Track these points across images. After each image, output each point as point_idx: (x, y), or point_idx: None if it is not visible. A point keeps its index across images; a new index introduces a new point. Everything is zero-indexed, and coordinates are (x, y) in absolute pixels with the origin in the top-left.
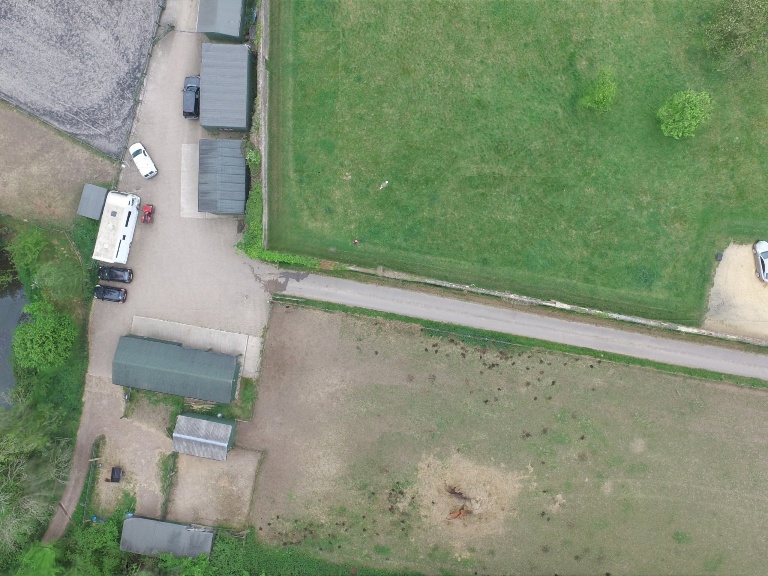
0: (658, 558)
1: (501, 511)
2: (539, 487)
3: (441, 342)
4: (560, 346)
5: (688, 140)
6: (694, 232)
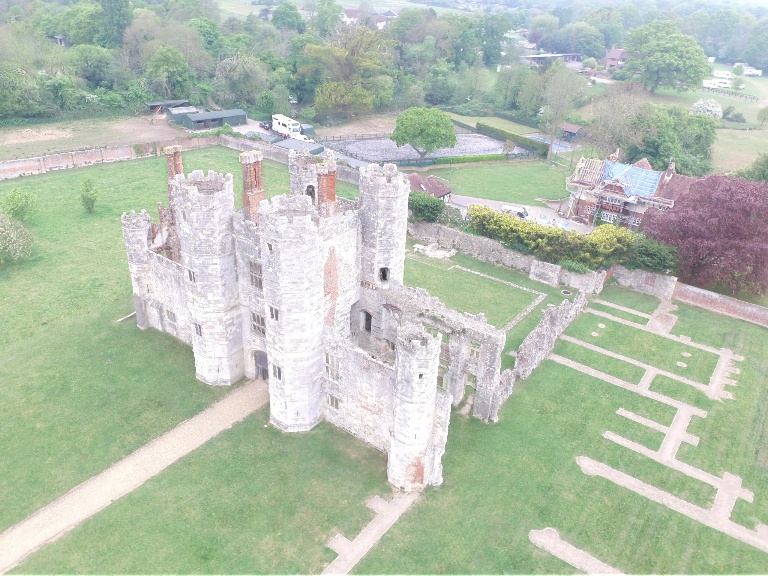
0: None
1: None
2: None
3: None
4: None
5: None
6: None
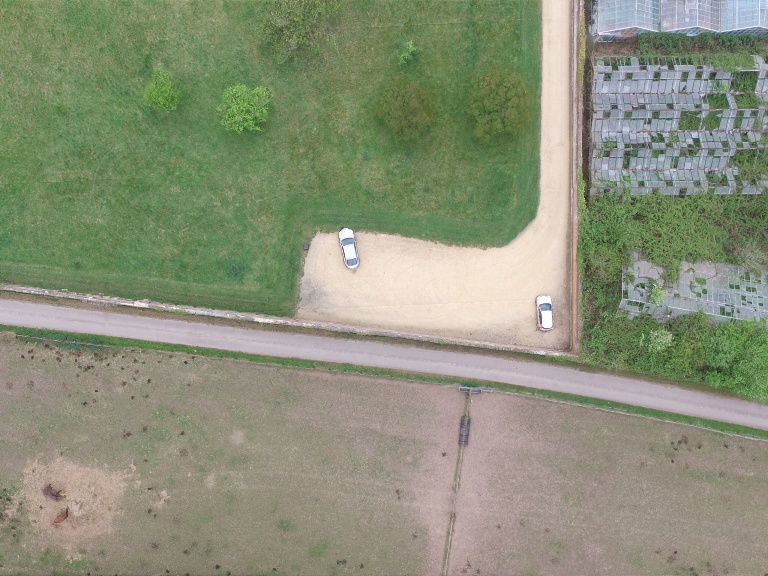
0: (265, 547)
1: (108, 511)
2: (144, 485)
3: (37, 348)
4: (153, 344)
5: (268, 134)
6: (281, 224)
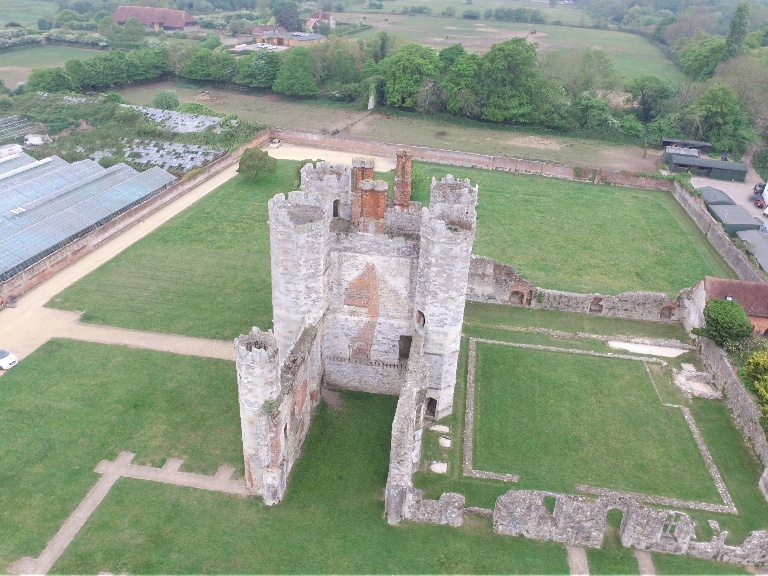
0: None
1: None
2: None
3: None
4: None
5: None
6: None
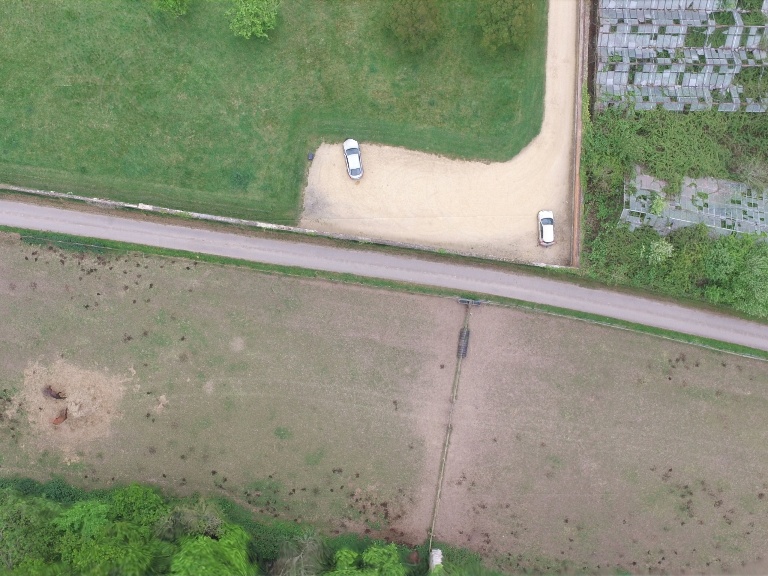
0: (261, 454)
1: (107, 414)
2: (143, 389)
3: (40, 250)
4: (156, 249)
5: (275, 43)
6: (286, 133)
